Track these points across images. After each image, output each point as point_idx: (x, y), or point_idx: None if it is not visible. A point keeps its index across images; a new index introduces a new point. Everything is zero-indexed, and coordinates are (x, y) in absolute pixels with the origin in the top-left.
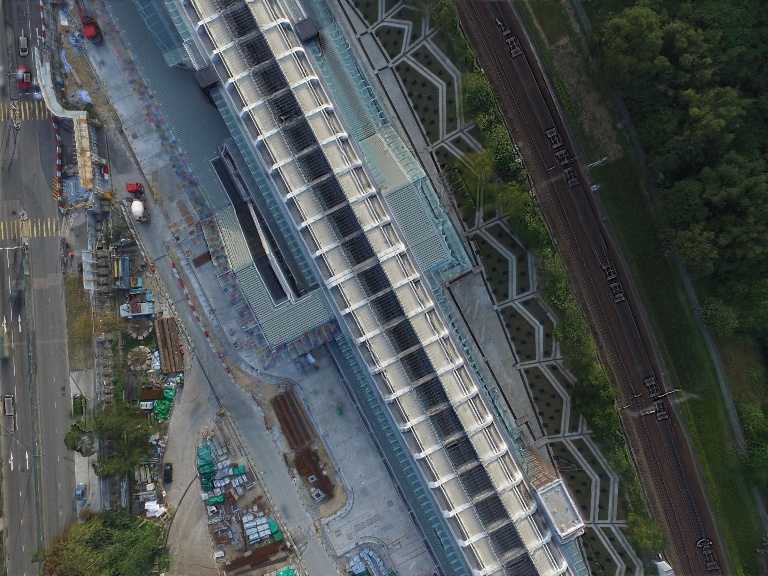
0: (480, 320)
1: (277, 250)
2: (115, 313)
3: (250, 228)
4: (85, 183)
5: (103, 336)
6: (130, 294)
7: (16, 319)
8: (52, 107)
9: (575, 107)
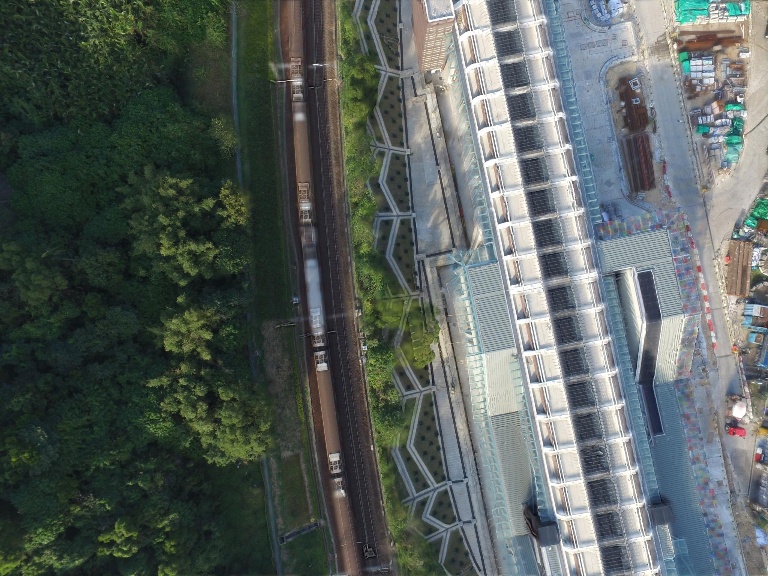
0: (432, 207)
1: None
2: None
3: (648, 356)
4: None
5: None
6: (767, 328)
7: None
8: None
9: (291, 386)
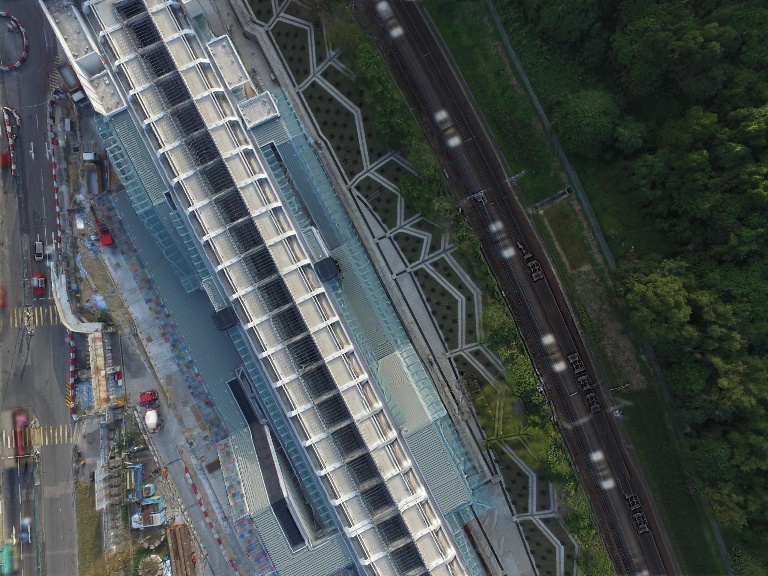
0: (499, 531)
1: (294, 477)
2: (126, 522)
3: (267, 460)
4: (99, 403)
5: (114, 550)
6: (142, 505)
7: (26, 530)
8: (67, 320)
9: (597, 331)
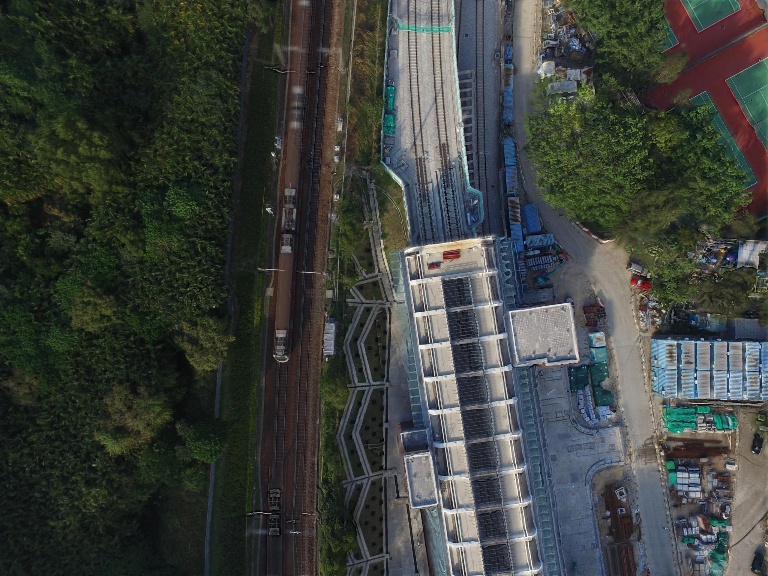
0: None
1: None
2: None
3: None
4: None
5: None
6: None
7: None
8: None
9: None
